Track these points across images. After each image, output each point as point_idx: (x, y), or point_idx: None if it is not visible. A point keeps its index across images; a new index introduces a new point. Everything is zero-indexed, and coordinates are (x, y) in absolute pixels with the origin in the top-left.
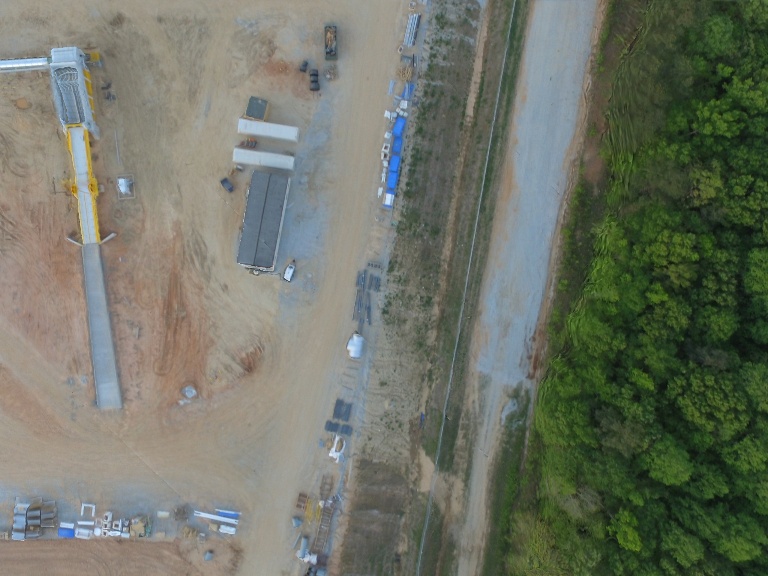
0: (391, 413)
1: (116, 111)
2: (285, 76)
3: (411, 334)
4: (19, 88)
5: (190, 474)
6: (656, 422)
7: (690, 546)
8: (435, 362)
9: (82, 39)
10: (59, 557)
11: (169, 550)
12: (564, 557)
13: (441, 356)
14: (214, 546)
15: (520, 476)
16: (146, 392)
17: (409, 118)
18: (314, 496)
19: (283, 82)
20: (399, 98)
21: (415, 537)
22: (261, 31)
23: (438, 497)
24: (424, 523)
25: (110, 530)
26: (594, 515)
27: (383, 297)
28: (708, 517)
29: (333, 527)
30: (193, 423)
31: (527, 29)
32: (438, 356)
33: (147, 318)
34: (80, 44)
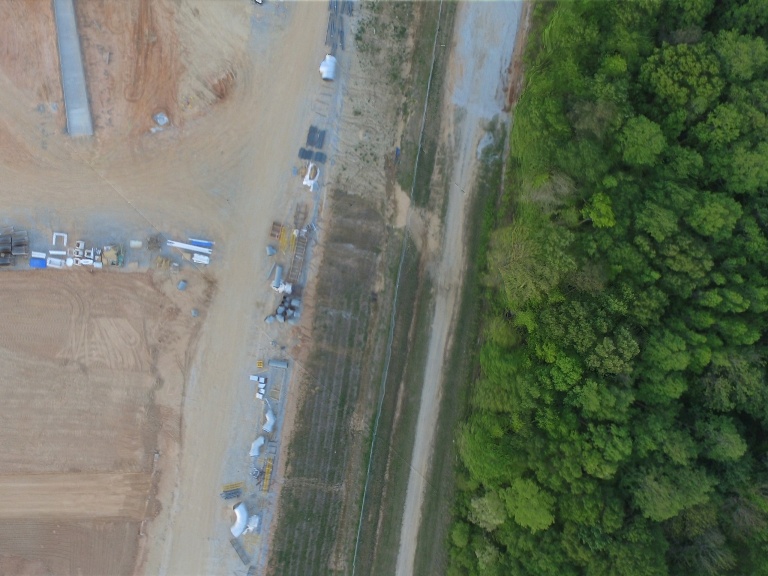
0: (366, 145)
1: None
2: None
3: (385, 65)
4: None
5: (163, 203)
6: (629, 101)
7: (664, 218)
8: (410, 95)
9: None
10: (31, 288)
11: (142, 281)
12: (538, 244)
13: (416, 88)
14: (188, 277)
15: (497, 210)
16: (117, 119)
17: None
18: (288, 226)
19: None
20: None
21: (391, 274)
22: None
23: (414, 233)
24: (400, 259)
25: (82, 258)
26: (567, 197)
27: (356, 22)
28: (682, 188)
29: (308, 257)
30: (165, 151)
31: None
32: (413, 88)
33: (117, 43)
34: None
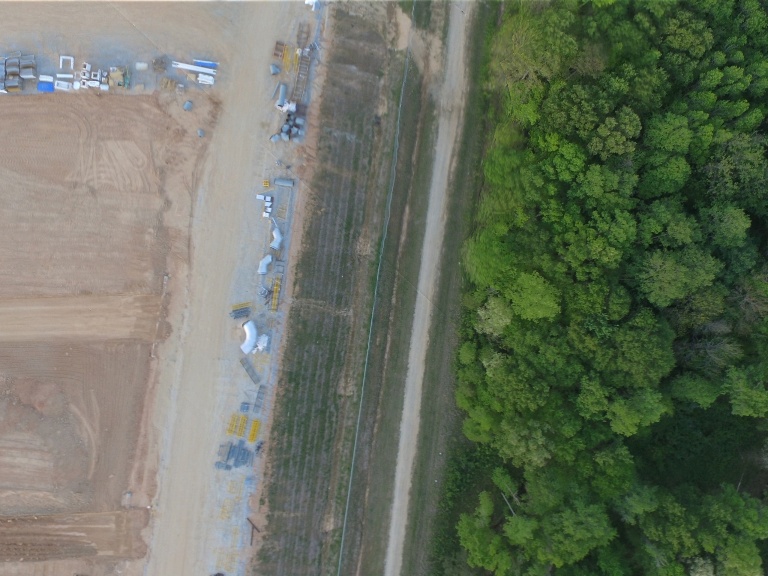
0: None
1: None
2: None
3: None
4: None
5: (167, 25)
6: None
7: None
8: None
9: None
10: (39, 112)
11: (148, 103)
12: (538, 31)
13: None
14: (193, 98)
15: (497, 29)
16: None
17: None
18: (291, 45)
19: None
20: None
21: (394, 97)
22: None
23: (416, 55)
24: (403, 80)
25: (89, 80)
26: None
27: None
28: None
29: (311, 77)
30: None
31: None
32: None
33: None
34: None
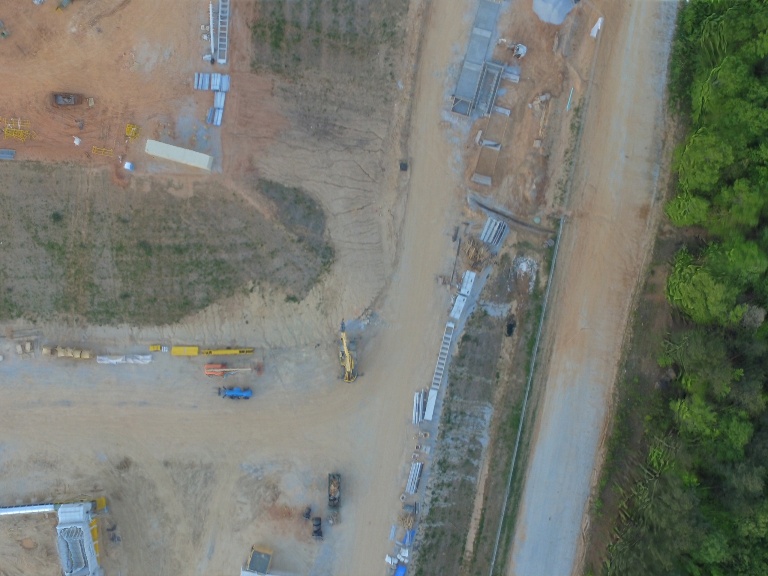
0: None
1: (121, 552)
2: (288, 521)
3: None
4: (25, 529)
5: None
6: None
7: None
8: None
9: (89, 482)
10: None
11: None
12: None
13: None
14: None
15: None
16: None
17: (410, 562)
18: None
19: (286, 526)
20: (400, 544)
21: None
22: (266, 476)
23: None
24: None
25: None
26: None
27: None
28: None
29: None
30: None
31: (528, 470)
32: None
33: None
34: (87, 486)
